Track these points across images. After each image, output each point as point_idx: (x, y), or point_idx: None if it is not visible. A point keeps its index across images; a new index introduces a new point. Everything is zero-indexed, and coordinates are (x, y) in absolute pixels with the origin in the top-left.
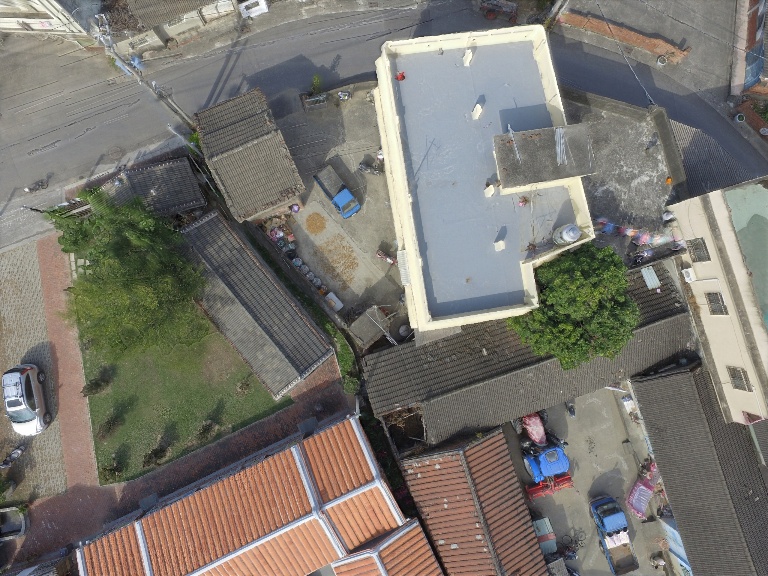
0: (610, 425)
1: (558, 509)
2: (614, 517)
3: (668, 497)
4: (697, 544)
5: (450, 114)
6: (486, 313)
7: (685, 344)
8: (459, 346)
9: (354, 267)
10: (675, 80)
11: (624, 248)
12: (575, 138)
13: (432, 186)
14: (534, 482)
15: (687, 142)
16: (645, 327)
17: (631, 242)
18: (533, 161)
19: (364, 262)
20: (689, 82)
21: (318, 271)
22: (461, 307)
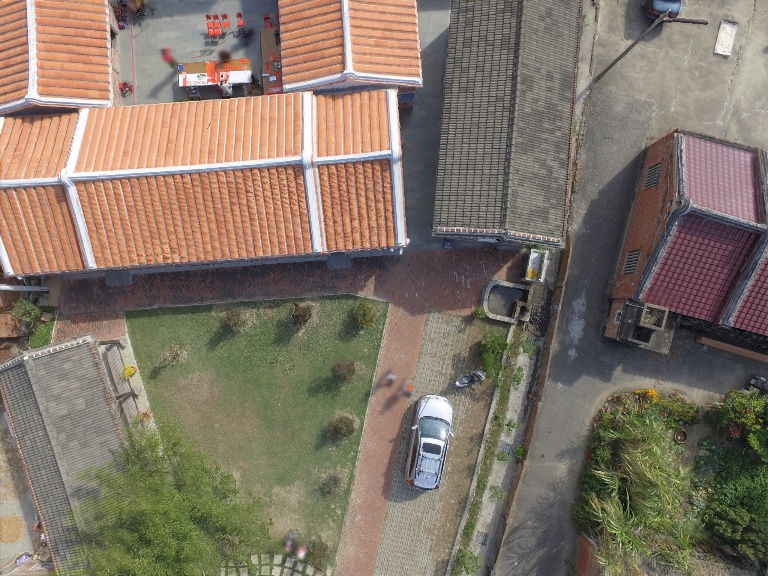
0: None
1: None
2: None
3: None
4: None
5: None
6: None
7: None
8: None
9: None
10: None
11: None
12: None
13: None
14: None
15: None
16: None
17: None
18: None
19: None
20: None
21: None
22: None
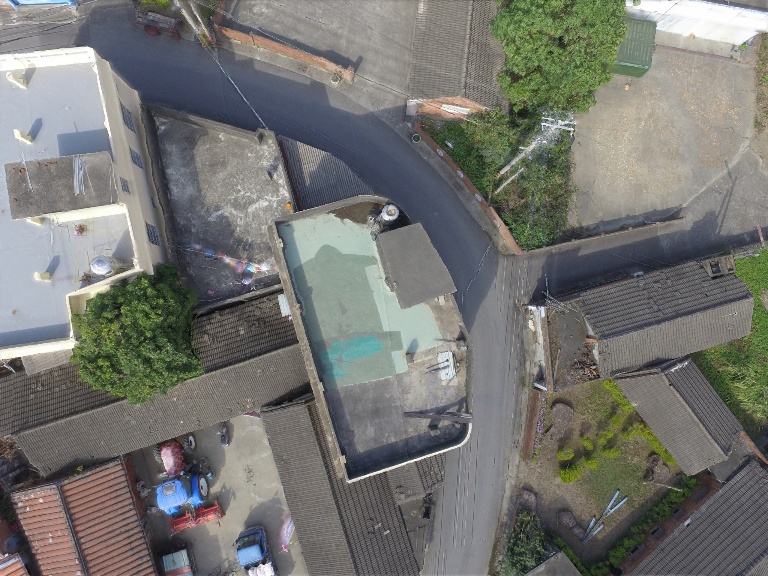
0: (271, 453)
1: (212, 540)
2: (248, 550)
3: None
4: None
5: (2, 138)
6: (15, 347)
7: None
8: (73, 375)
9: None
10: (351, 99)
11: (238, 275)
12: (96, 167)
13: None
14: (184, 512)
15: (315, 166)
16: (259, 357)
17: (246, 269)
18: (48, 191)
19: None
20: (366, 101)
21: None
22: (5, 340)
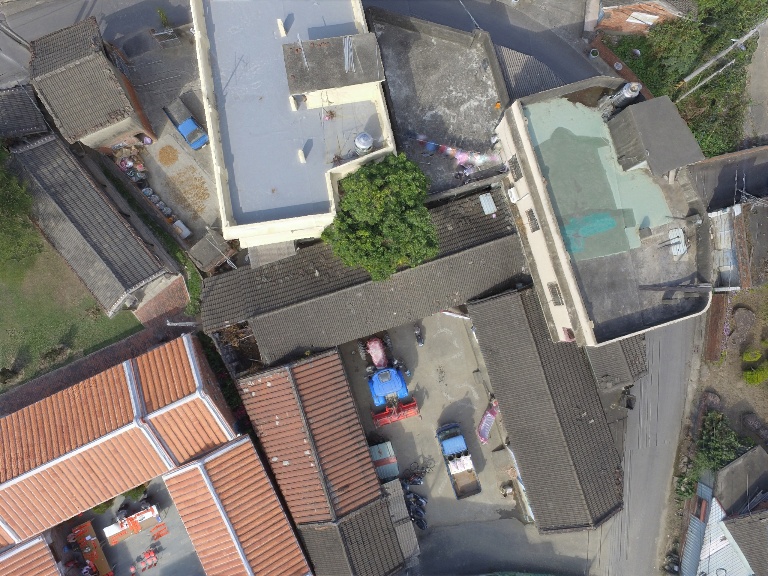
0: (461, 355)
1: (407, 437)
2: (452, 440)
3: (502, 419)
4: (529, 465)
5: (259, 32)
6: (283, 219)
7: (520, 268)
8: (294, 268)
9: (205, 198)
10: (530, 17)
11: (452, 170)
12: (364, 46)
13: (240, 101)
14: (382, 409)
15: (519, 68)
16: (473, 248)
17: (459, 165)
18: (321, 68)
19: (215, 193)
20: (544, 19)
21: (170, 201)
22: (266, 216)
